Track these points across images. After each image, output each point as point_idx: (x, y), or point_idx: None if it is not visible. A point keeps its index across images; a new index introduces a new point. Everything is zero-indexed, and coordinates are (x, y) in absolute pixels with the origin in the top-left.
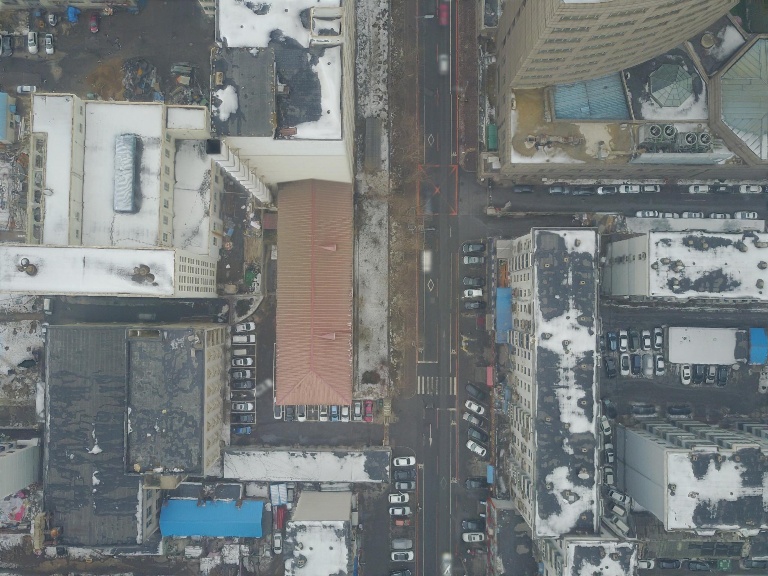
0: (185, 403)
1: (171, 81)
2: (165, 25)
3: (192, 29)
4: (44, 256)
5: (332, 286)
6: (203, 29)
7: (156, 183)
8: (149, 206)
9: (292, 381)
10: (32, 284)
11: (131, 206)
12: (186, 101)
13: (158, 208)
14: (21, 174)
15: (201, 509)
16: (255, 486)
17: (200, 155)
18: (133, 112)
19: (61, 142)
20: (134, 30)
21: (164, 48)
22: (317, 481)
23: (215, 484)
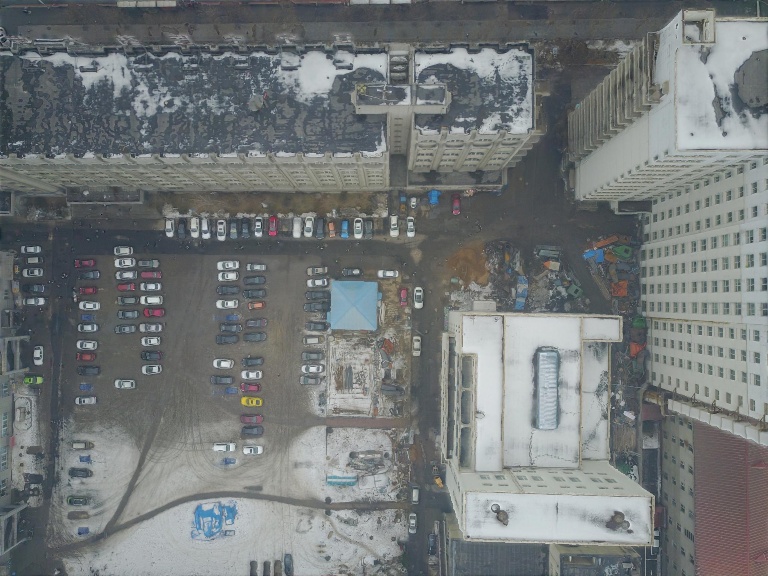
0: None
1: (534, 264)
2: (526, 206)
3: (555, 210)
4: (515, 502)
5: (760, 505)
6: (566, 210)
7: (574, 397)
8: (568, 421)
9: None
10: (503, 530)
11: (556, 425)
12: (552, 285)
13: (578, 423)
14: (386, 361)
15: None
16: None
17: (596, 356)
18: (549, 324)
19: (490, 362)
20: (495, 211)
21: (526, 230)
22: None
23: None
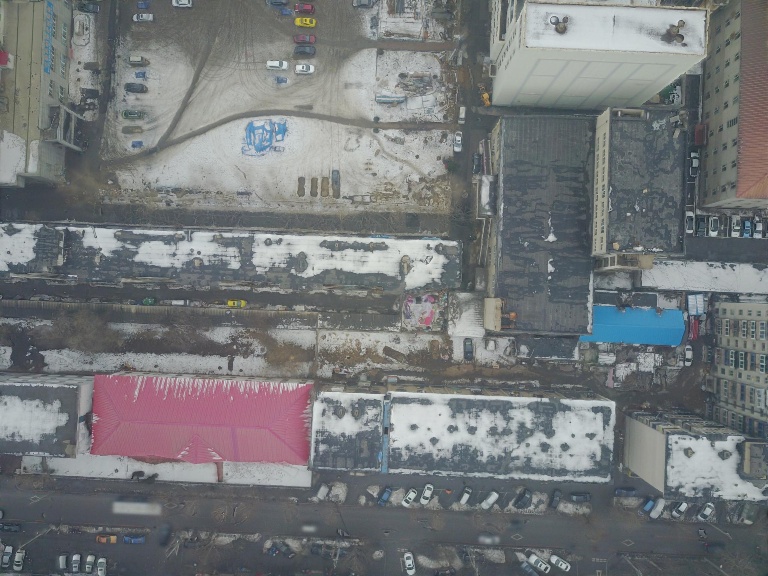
0: (666, 184)
1: None
2: None
3: None
4: (573, 14)
5: None
6: None
7: None
8: None
9: (762, 170)
10: (561, 42)
11: None
12: None
13: None
14: None
15: (622, 314)
16: (664, 299)
17: None
18: None
19: None
20: None
21: None
22: (736, 292)
23: (631, 292)
